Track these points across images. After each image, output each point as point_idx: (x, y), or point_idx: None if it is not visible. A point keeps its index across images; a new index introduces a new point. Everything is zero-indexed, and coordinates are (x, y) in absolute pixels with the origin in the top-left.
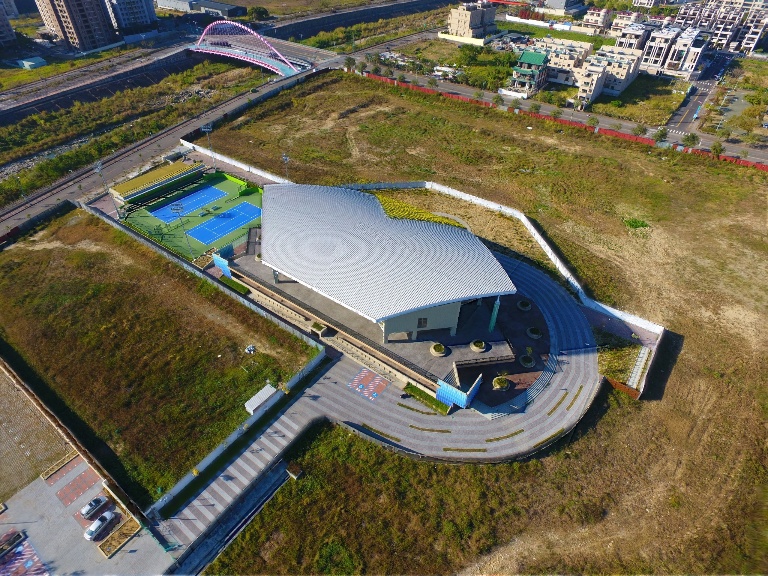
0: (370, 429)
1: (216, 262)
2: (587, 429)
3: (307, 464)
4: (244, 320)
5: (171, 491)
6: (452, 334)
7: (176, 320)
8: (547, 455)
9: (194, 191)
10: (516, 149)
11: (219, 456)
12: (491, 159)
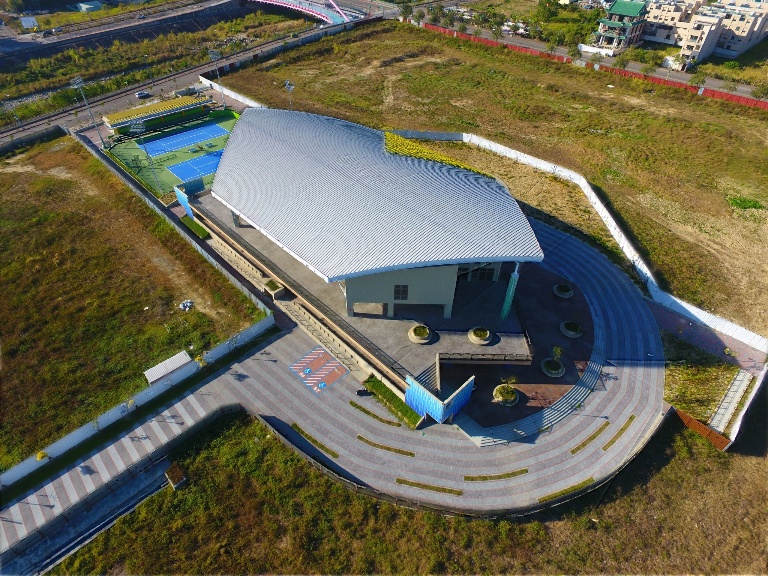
0: (300, 432)
1: (179, 198)
2: (632, 486)
3: (195, 469)
4: (191, 269)
5: (0, 477)
6: (446, 315)
7: (115, 260)
8: (558, 518)
9: (195, 127)
10: (589, 108)
11: (89, 438)
12: (554, 116)
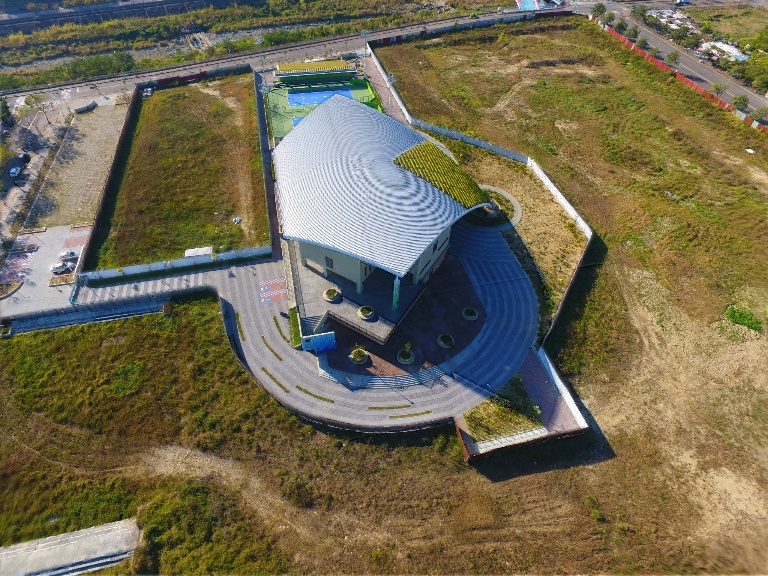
0: (237, 319)
1: None
2: (383, 443)
3: (177, 311)
4: (254, 198)
5: (100, 272)
6: (358, 290)
7: (220, 176)
8: (325, 432)
9: (334, 89)
10: (695, 168)
11: (146, 272)
12: (644, 166)
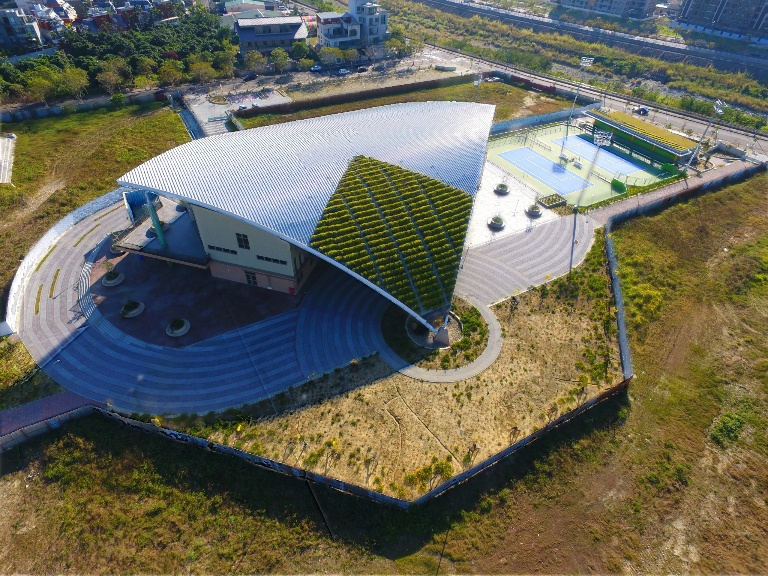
0: None
1: None
2: (9, 282)
3: None
4: None
5: None
6: None
7: None
8: None
9: (628, 159)
10: None
11: None
12: None
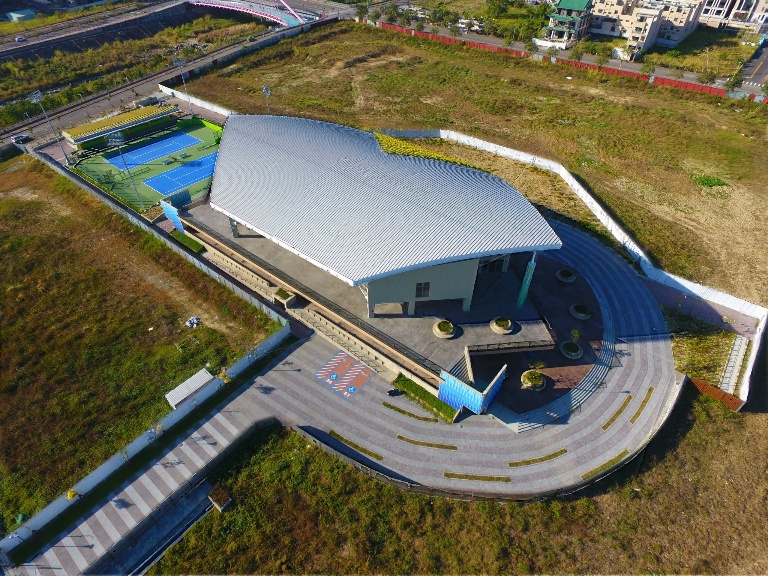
0: (340, 439)
1: (166, 212)
2: (664, 453)
3: (240, 489)
4: (191, 284)
5: (29, 523)
6: (465, 308)
7: (105, 282)
8: (604, 491)
9: (164, 138)
10: (553, 99)
11: (117, 470)
12: (522, 109)
